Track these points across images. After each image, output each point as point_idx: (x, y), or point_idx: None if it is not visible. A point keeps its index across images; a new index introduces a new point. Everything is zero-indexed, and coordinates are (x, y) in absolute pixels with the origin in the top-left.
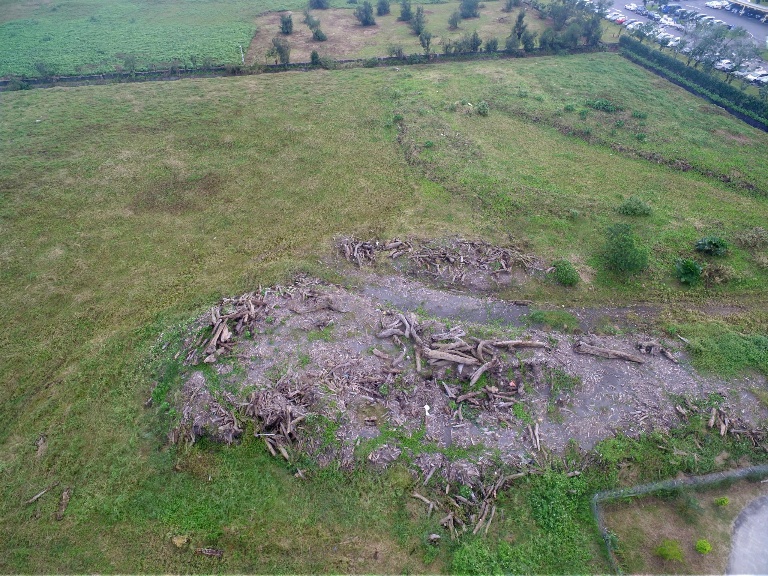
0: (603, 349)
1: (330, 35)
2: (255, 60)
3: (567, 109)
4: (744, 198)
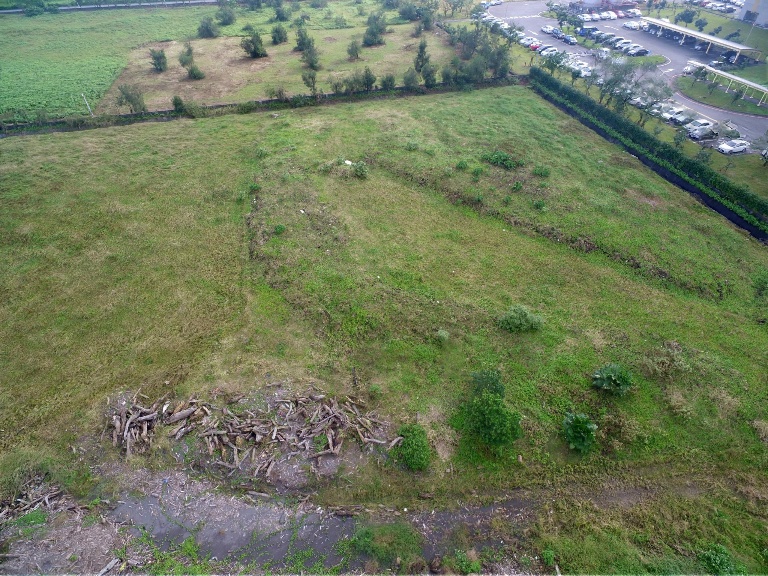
0: None
1: (211, 71)
2: (110, 107)
3: (459, 167)
4: (656, 291)
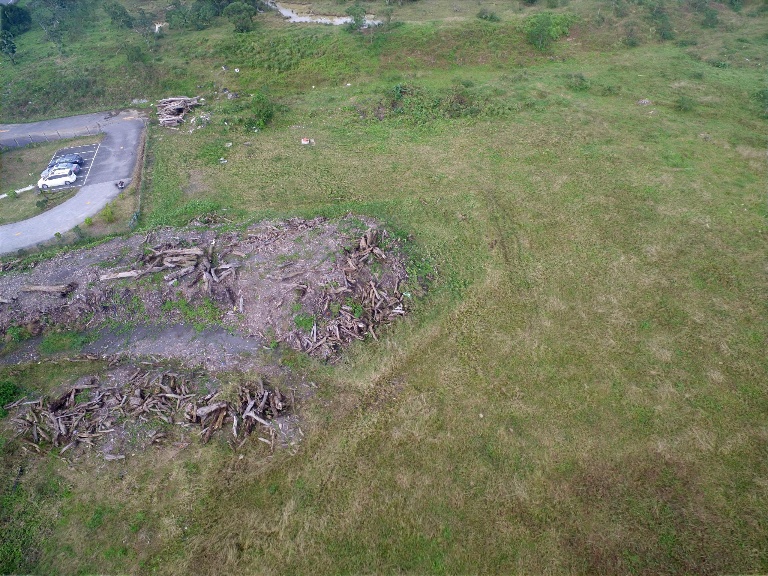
0: (51, 287)
1: None
2: None
3: None
4: None
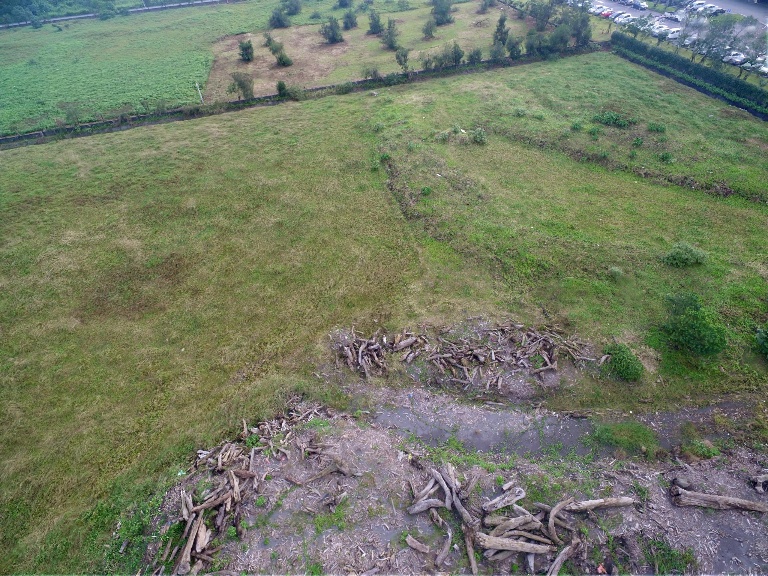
0: (710, 497)
1: (296, 58)
2: (215, 96)
3: (574, 128)
4: None
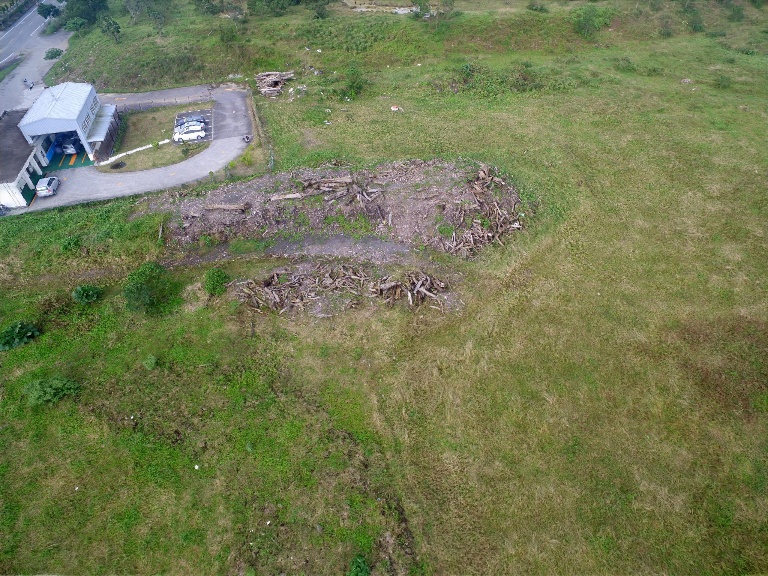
0: (231, 205)
1: None
2: None
3: None
4: None
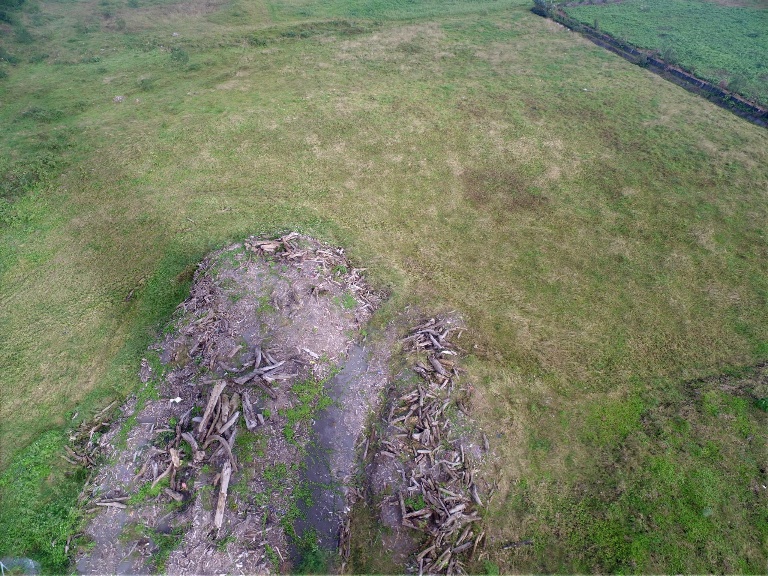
0: None
1: None
2: None
3: None
4: None
